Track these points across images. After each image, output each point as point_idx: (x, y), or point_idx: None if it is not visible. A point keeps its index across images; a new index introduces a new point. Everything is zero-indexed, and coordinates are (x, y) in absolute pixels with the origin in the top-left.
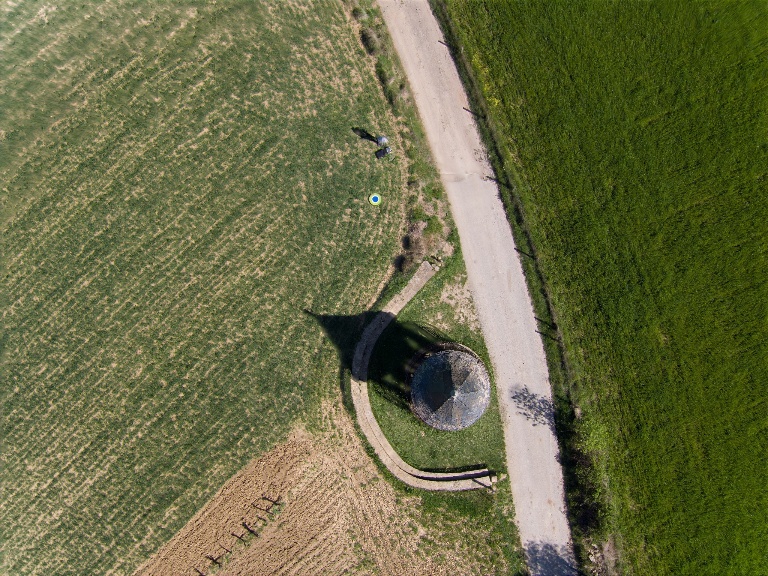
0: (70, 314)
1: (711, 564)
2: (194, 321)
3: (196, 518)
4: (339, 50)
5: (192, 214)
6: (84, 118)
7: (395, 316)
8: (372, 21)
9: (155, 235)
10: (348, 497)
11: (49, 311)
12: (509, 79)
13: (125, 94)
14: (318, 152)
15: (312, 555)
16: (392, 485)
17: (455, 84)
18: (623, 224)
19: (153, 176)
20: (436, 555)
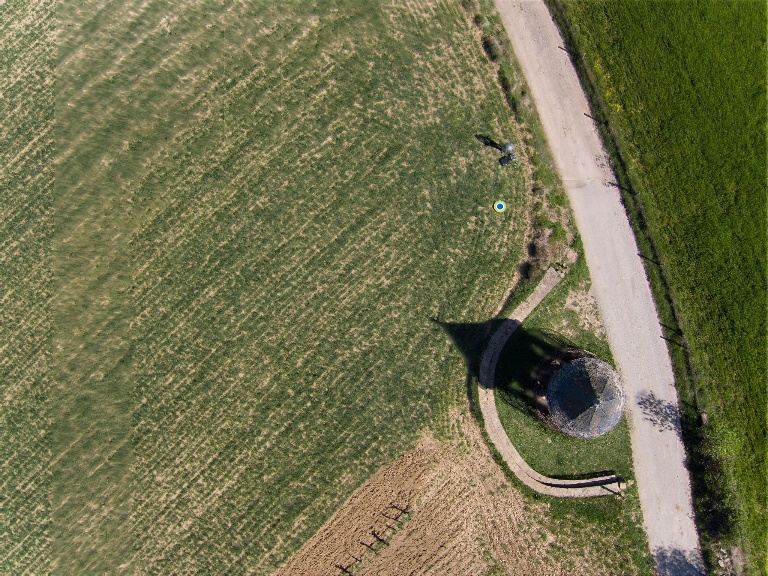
0: (196, 324)
1: None
2: (320, 330)
3: (325, 527)
4: (461, 57)
5: (317, 223)
6: (208, 128)
7: (521, 323)
8: (493, 28)
9: (280, 244)
10: (476, 505)
11: (175, 322)
12: (630, 84)
13: (248, 103)
14: (442, 160)
15: (441, 563)
16: (520, 492)
17: (576, 90)
18: (746, 229)
19: (277, 185)
20: (565, 562)
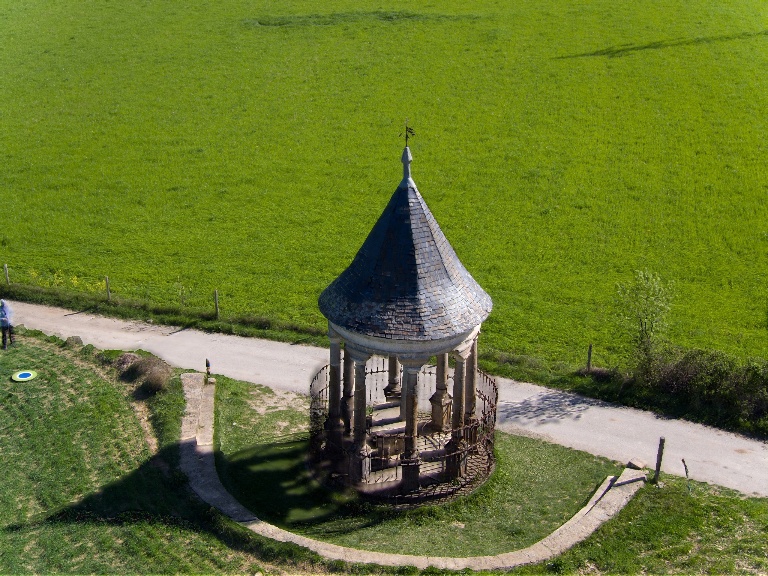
0: None
1: None
2: None
3: None
4: None
5: None
6: None
7: (212, 445)
8: None
9: None
10: None
11: None
12: None
13: None
14: None
15: None
16: None
17: (30, 310)
18: None
19: None
20: None
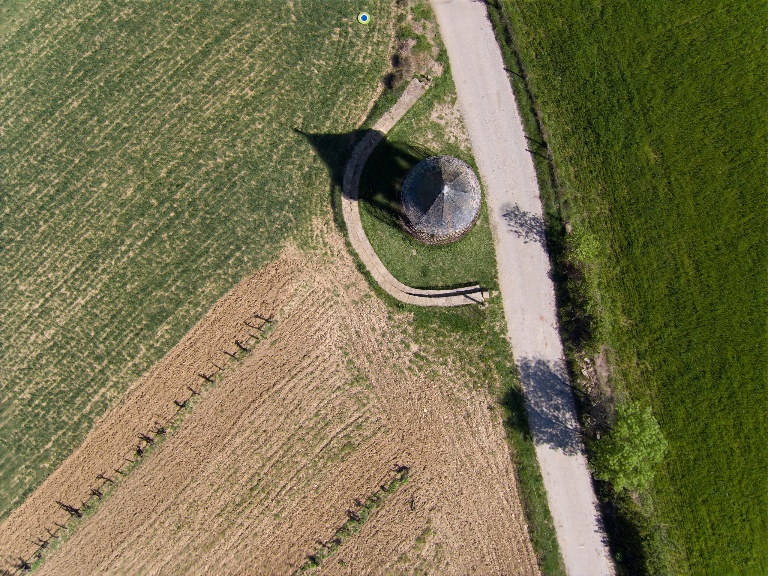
0: (60, 135)
1: (703, 378)
2: (184, 141)
3: (188, 337)
4: None
5: (181, 34)
6: None
7: (385, 135)
8: None
9: (144, 56)
10: (340, 315)
11: (39, 132)
12: None
13: None
14: None
15: (305, 373)
16: (384, 302)
17: None
18: (612, 43)
19: None
20: (429, 371)
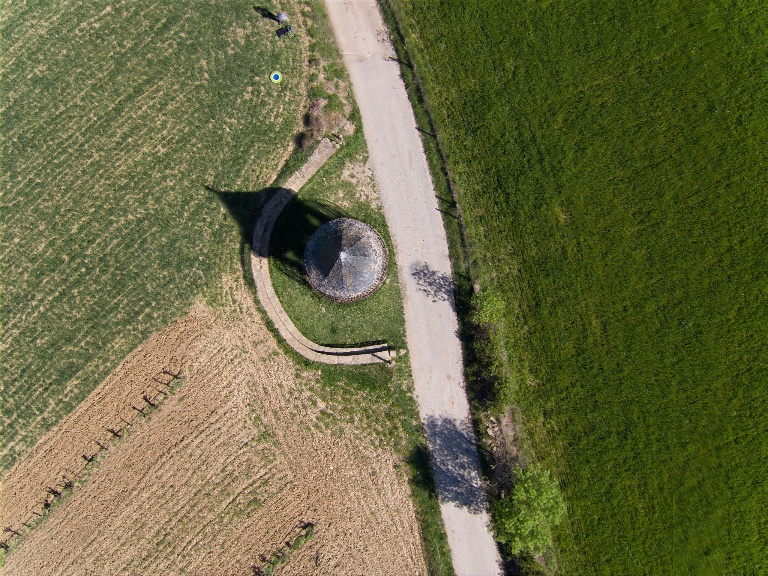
0: None
1: (609, 439)
2: (96, 197)
3: (97, 392)
4: None
5: (94, 91)
6: None
7: (296, 193)
8: None
9: (58, 112)
10: (248, 371)
11: None
12: None
13: None
14: (220, 30)
15: (212, 428)
16: (292, 359)
17: None
18: (523, 104)
19: (56, 54)
20: (335, 429)
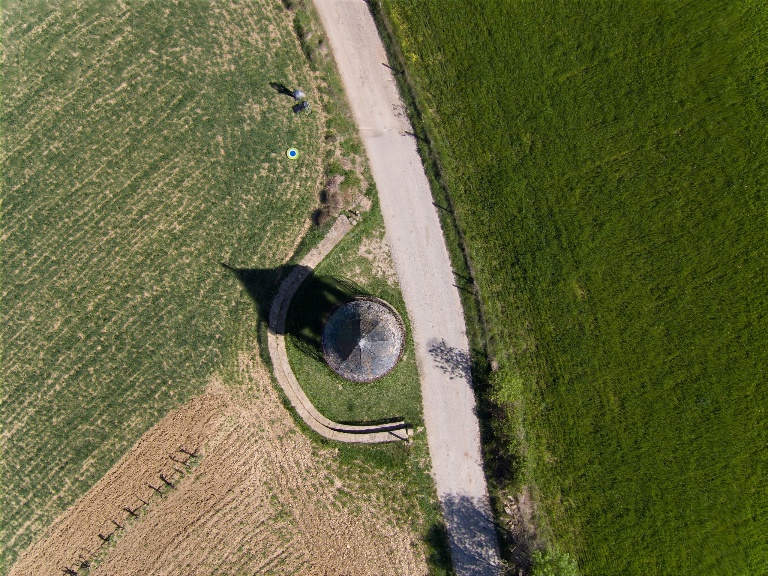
0: None
1: (627, 516)
2: (112, 275)
3: (113, 470)
4: (257, 5)
5: (110, 168)
6: (2, 73)
7: (312, 270)
8: None
9: (73, 189)
10: (265, 450)
11: None
12: (428, 35)
13: (43, 49)
14: (236, 107)
15: (229, 507)
16: (309, 438)
17: (374, 40)
18: (541, 179)
19: (71, 130)
20: (352, 507)
